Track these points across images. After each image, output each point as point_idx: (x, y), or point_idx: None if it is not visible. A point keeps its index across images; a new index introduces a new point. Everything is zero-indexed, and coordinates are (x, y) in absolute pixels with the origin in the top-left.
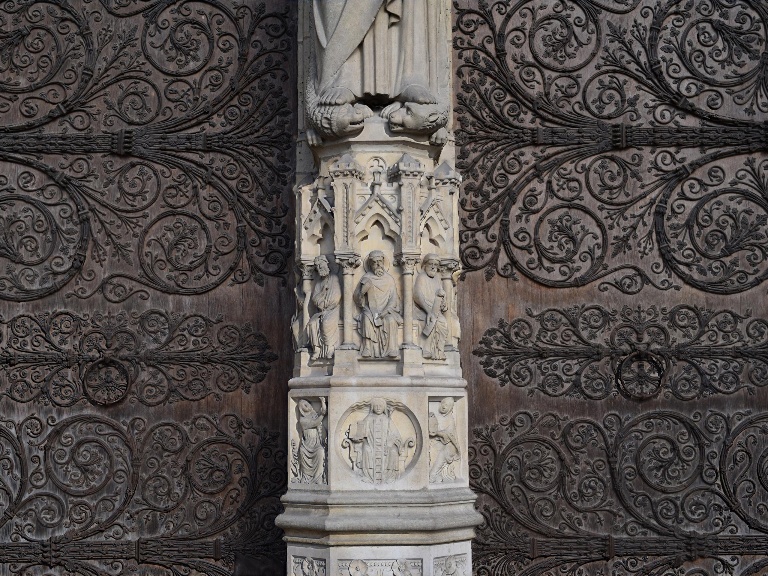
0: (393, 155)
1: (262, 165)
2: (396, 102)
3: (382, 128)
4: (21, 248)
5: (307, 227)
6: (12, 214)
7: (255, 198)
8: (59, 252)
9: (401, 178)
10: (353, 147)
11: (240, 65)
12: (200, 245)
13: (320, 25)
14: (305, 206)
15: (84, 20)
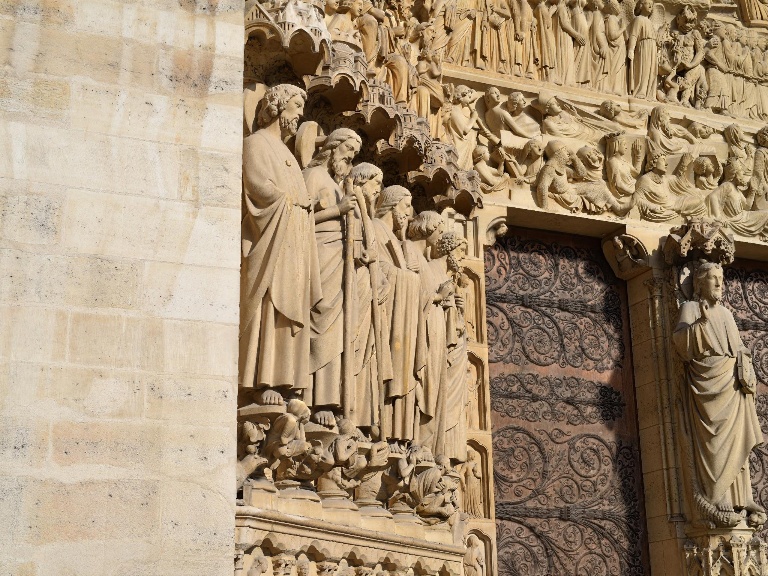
0: (748, 536)
1: (628, 528)
2: (744, 510)
3: (745, 523)
4: (520, 570)
5: (713, 569)
6: (514, 551)
7: (626, 546)
8: (538, 573)
9: (760, 548)
10: (733, 531)
11: (615, 473)
12: (603, 571)
13: (709, 470)
14: (711, 559)
15: (542, 444)
